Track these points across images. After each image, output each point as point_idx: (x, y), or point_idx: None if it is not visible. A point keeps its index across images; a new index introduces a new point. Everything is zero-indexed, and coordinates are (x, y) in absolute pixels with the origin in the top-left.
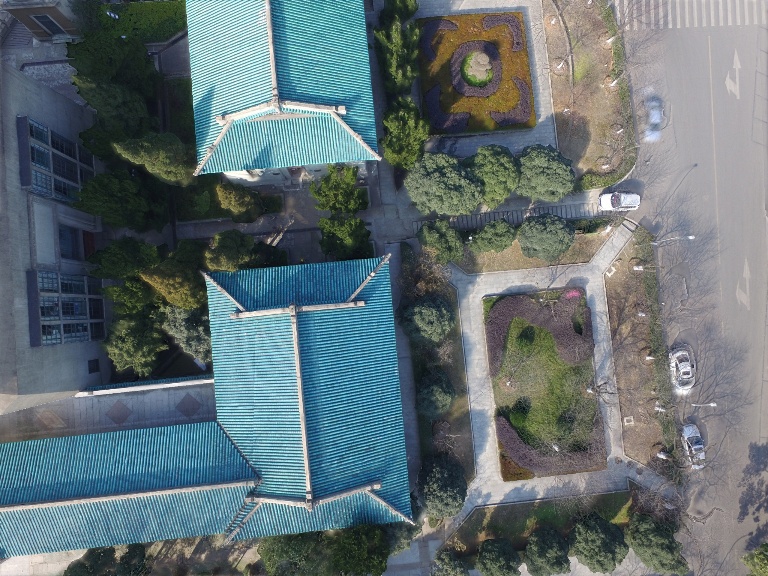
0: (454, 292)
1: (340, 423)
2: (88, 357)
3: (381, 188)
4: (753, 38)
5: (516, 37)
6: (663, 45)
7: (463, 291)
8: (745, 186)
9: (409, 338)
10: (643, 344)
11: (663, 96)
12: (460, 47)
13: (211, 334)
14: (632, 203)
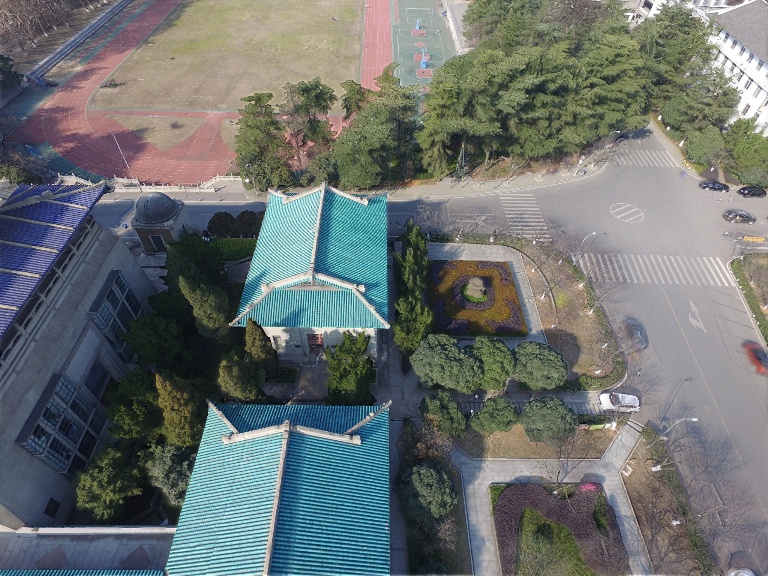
0: (458, 476)
1: (312, 574)
2: (53, 493)
3: (389, 372)
4: (701, 293)
5: (504, 276)
6: (627, 292)
7: (468, 476)
8: (743, 402)
9: (406, 521)
10: (690, 564)
11: (637, 325)
12: (460, 278)
13: (195, 463)
14: (631, 402)
